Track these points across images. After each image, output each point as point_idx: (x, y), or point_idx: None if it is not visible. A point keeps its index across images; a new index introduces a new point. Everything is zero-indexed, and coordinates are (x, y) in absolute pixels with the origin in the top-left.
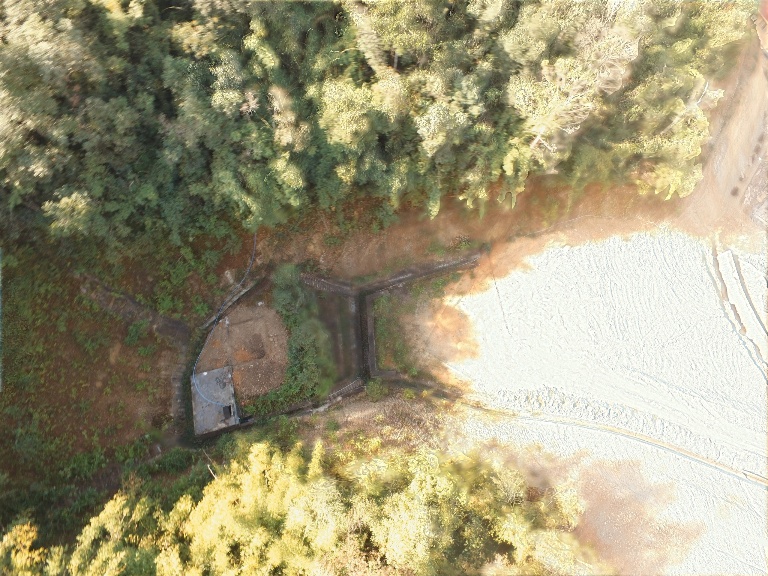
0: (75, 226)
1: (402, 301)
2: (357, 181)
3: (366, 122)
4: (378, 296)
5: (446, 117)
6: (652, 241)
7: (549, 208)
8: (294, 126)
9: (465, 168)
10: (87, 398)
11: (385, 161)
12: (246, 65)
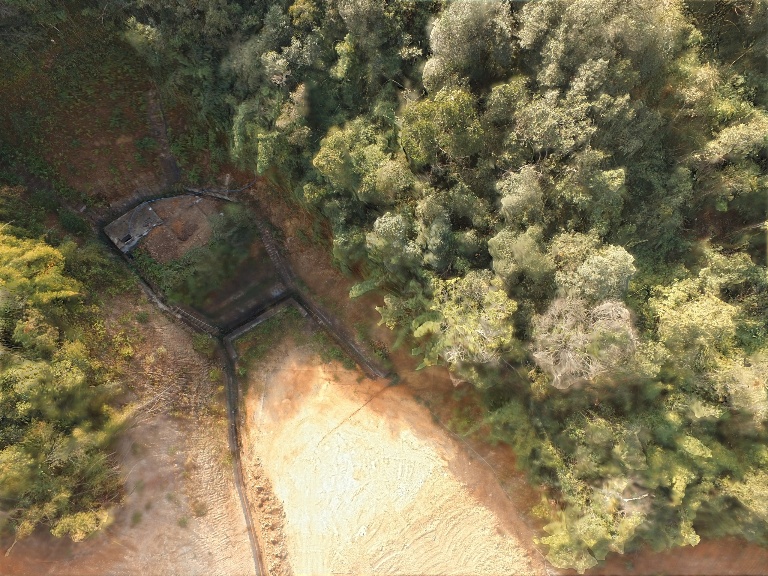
0: (155, 49)
1: (304, 330)
2: (321, 208)
3: (336, 169)
4: (296, 307)
5: (398, 233)
6: (523, 568)
7: (461, 416)
8: (298, 122)
9: (402, 293)
10: (82, 142)
11: (360, 221)
12: (334, 62)
